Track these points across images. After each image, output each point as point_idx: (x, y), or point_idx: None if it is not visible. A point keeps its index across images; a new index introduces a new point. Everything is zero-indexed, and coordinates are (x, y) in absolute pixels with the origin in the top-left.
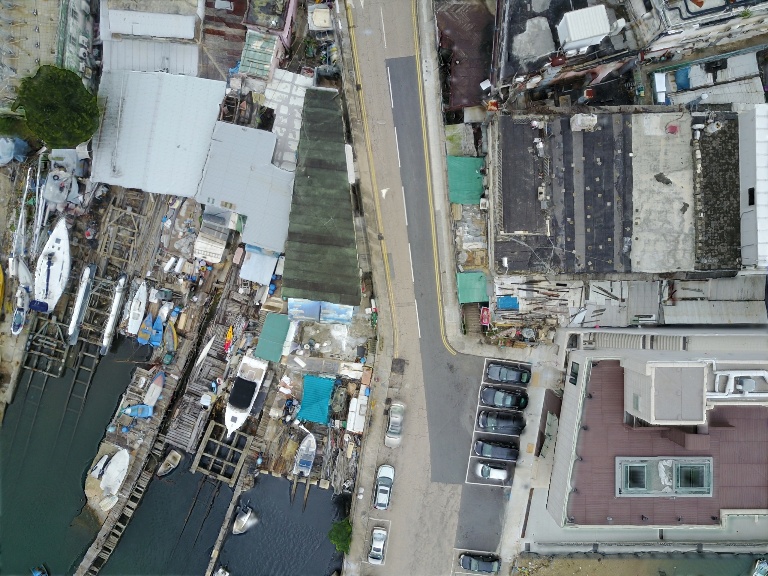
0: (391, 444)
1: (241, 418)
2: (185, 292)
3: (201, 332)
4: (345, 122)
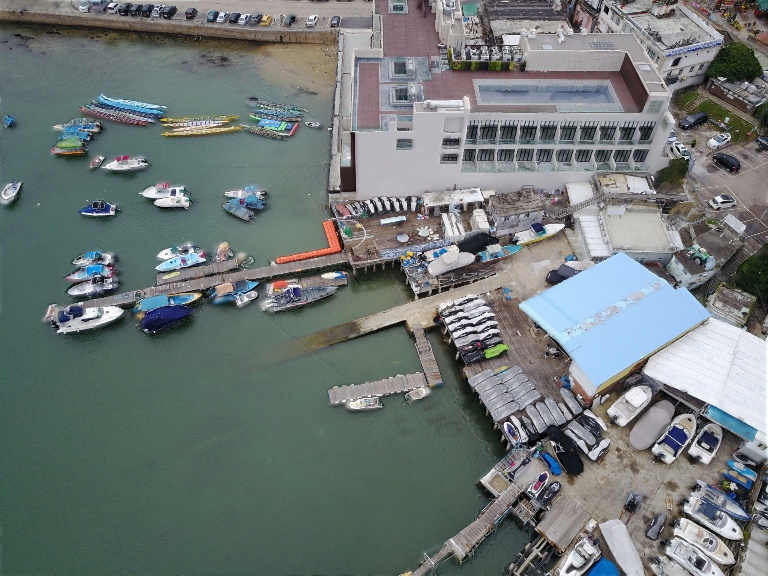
0: None
1: None
2: None
3: None
4: None
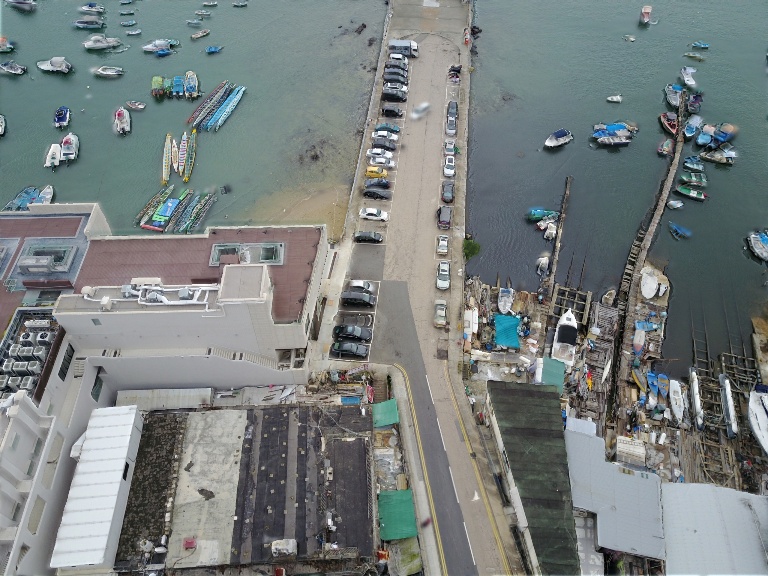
0: (442, 301)
1: (563, 320)
2: (640, 412)
3: (615, 386)
4: (529, 569)
